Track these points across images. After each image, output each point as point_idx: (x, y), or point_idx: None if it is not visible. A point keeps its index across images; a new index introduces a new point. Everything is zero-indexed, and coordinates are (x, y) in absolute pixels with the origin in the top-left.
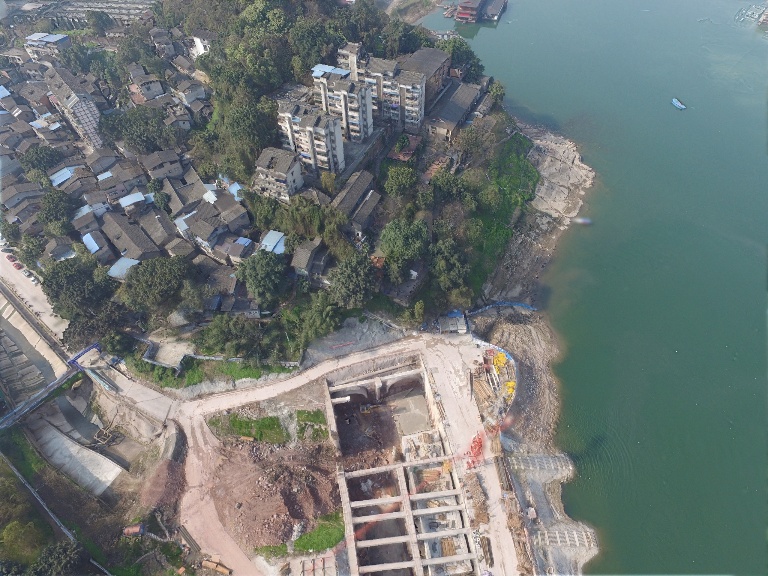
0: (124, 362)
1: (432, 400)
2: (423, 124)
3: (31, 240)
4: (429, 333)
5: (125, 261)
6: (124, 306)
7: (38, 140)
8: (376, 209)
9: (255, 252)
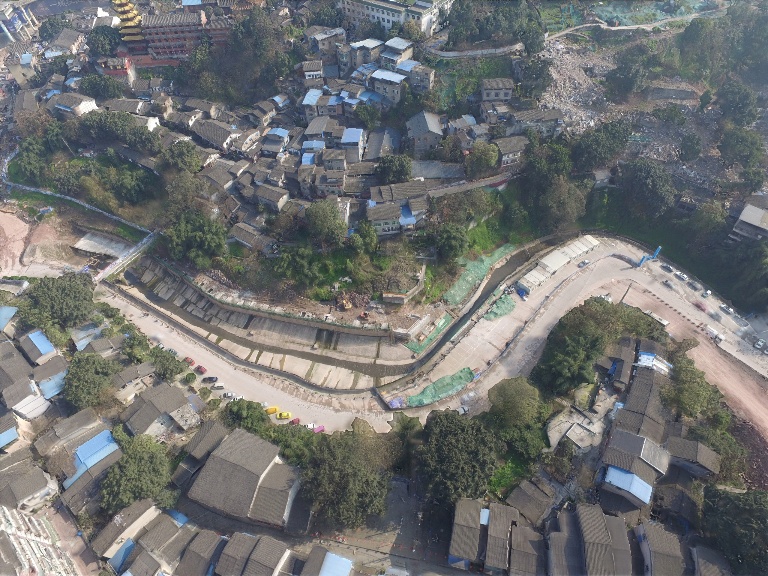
0: None
1: None
2: None
3: None
4: None
5: None
6: None
7: (188, 575)
8: None
9: None
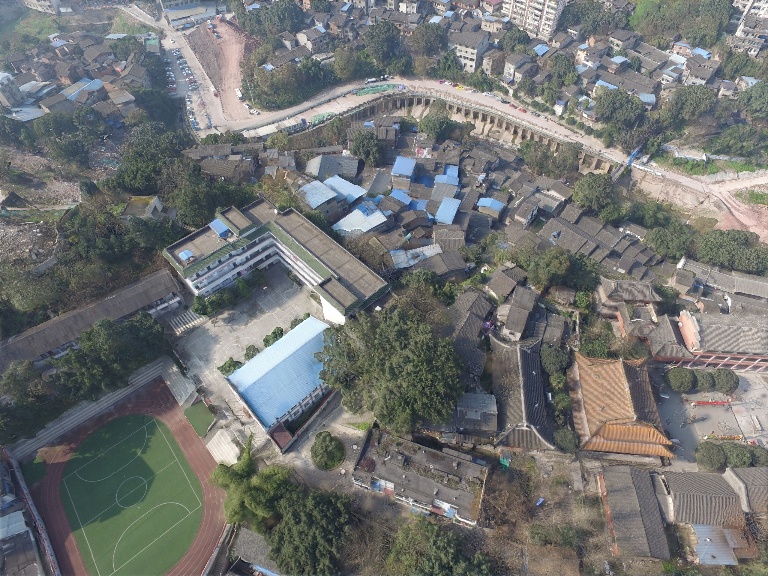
0: (654, 161)
1: None
2: None
3: (551, 86)
4: None
5: (645, 94)
6: (657, 121)
7: None
8: None
9: (746, 86)
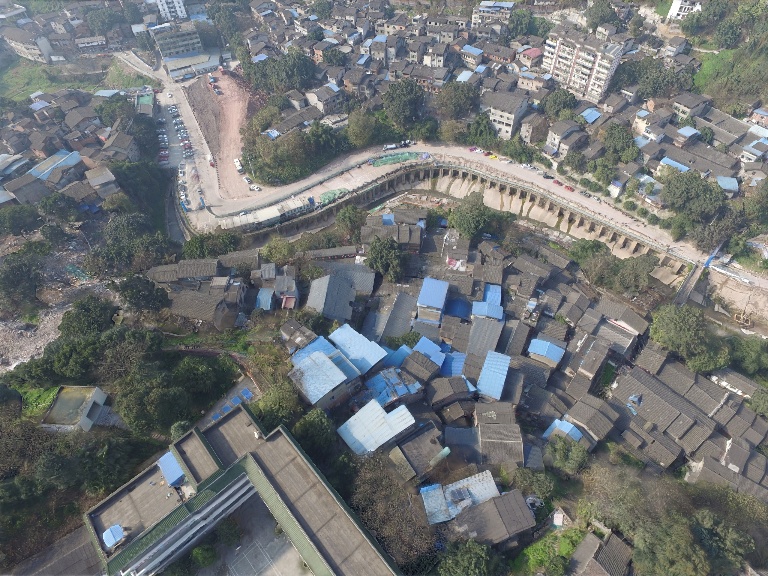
0: (737, 262)
1: None
2: None
3: (606, 164)
4: None
5: (724, 178)
6: (741, 214)
7: (524, 89)
8: None
9: None
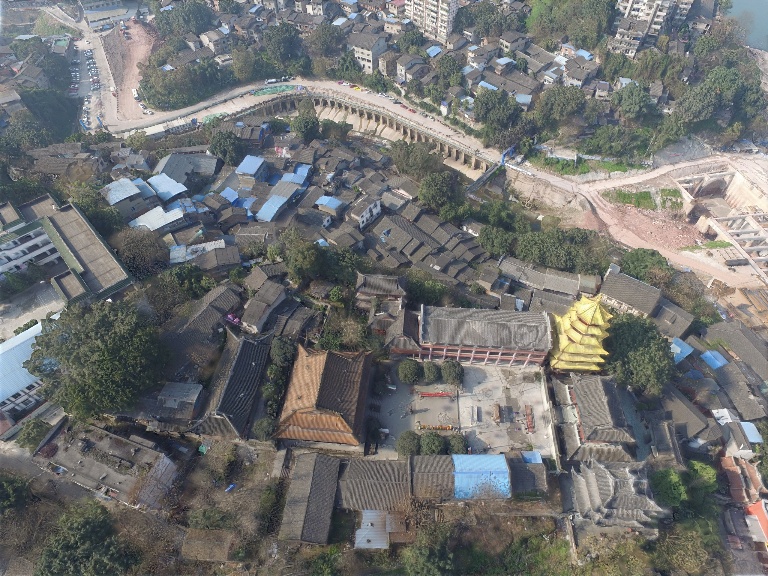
0: (528, 161)
1: (748, 188)
2: (685, 21)
3: (436, 87)
4: (728, 153)
5: (522, 95)
6: (531, 122)
7: None
8: (696, 62)
9: (620, 87)
